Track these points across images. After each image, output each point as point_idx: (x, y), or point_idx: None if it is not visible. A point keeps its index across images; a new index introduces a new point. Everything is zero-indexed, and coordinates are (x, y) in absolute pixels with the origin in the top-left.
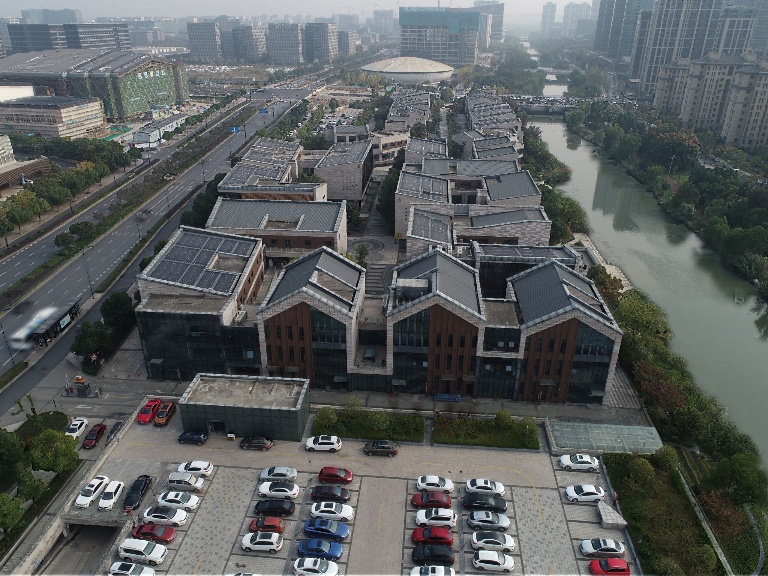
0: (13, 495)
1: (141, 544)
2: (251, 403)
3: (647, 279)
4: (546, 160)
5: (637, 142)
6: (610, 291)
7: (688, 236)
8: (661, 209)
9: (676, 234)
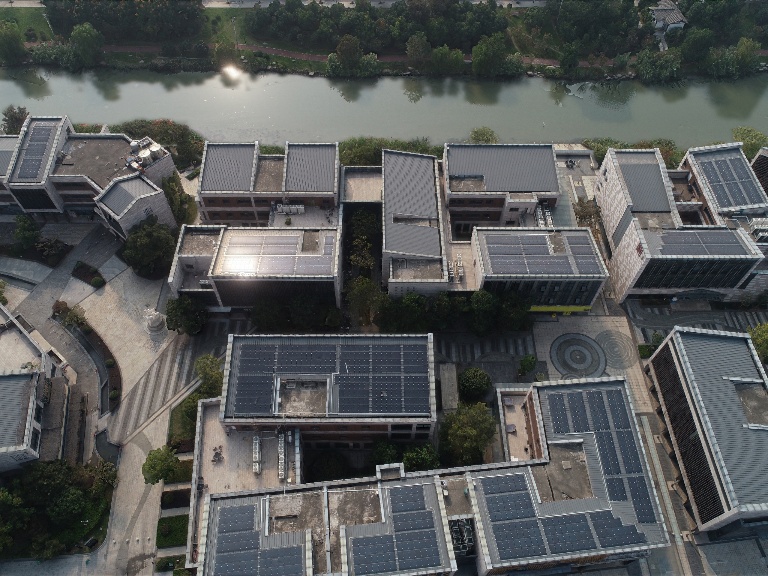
0: None
1: None
2: None
3: (542, 132)
4: (186, 132)
5: (93, 28)
6: (670, 151)
7: (419, 82)
8: (333, 79)
9: (414, 88)
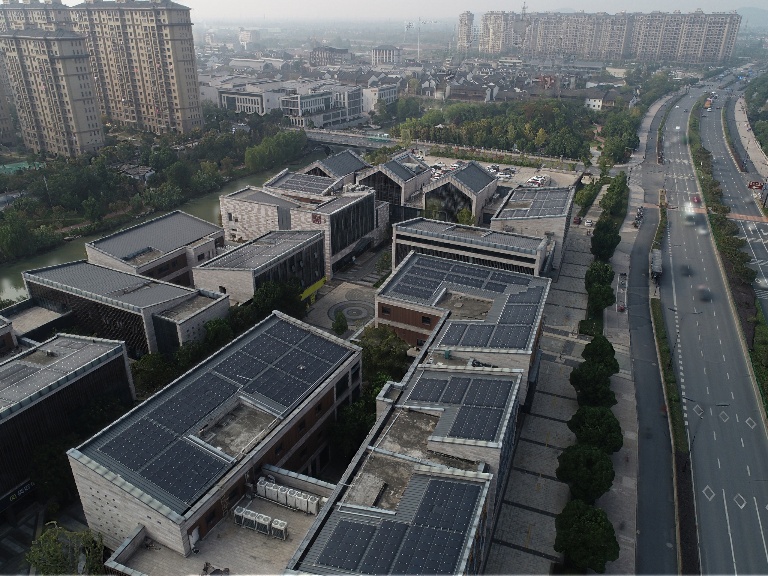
0: (599, 213)
1: (535, 178)
2: (501, 183)
3: None
4: None
5: None
6: None
7: None
8: None
9: None
